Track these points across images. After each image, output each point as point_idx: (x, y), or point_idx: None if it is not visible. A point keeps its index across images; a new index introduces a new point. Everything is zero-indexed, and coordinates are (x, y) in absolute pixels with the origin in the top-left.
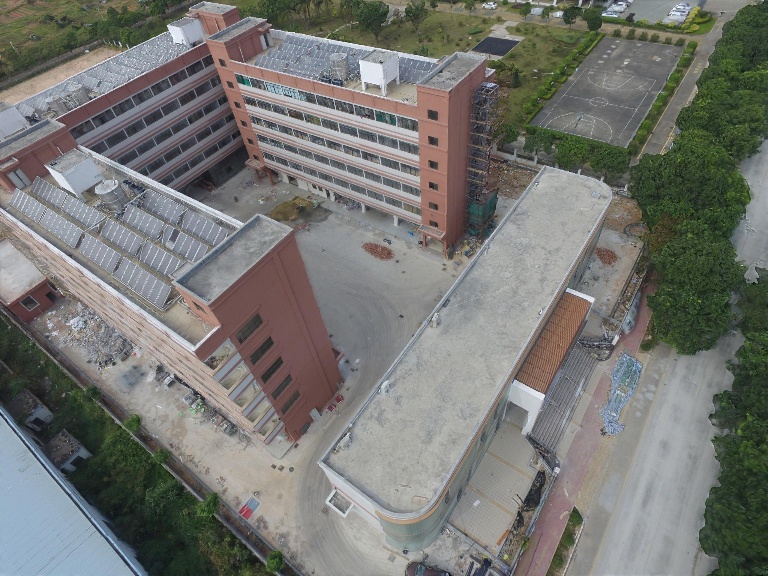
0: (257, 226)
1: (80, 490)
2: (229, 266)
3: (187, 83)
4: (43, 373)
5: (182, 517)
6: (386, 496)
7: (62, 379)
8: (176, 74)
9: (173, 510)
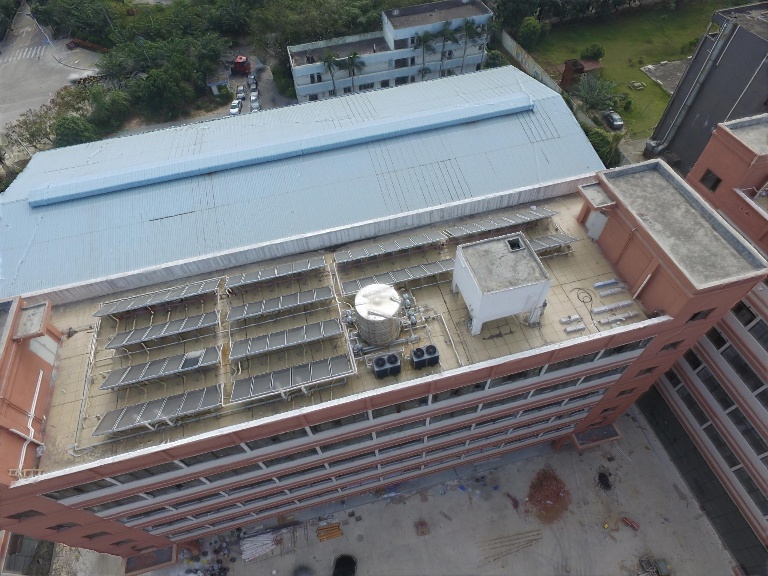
0: None
1: None
2: None
3: None
4: None
5: None
6: None
7: None
8: None
9: None
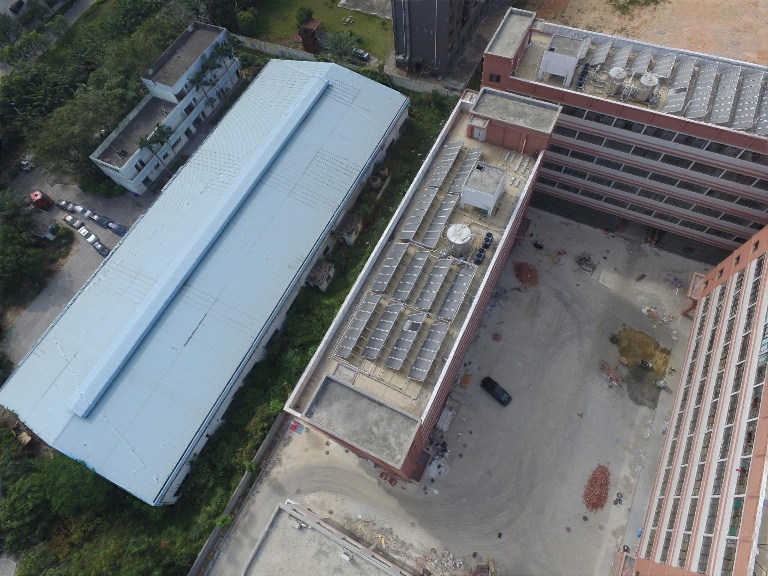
0: (409, 422)
1: (295, 301)
2: (353, 414)
3: (760, 169)
4: (386, 214)
5: (281, 383)
6: (257, 570)
7: (379, 234)
8: (760, 154)
9: (287, 373)
